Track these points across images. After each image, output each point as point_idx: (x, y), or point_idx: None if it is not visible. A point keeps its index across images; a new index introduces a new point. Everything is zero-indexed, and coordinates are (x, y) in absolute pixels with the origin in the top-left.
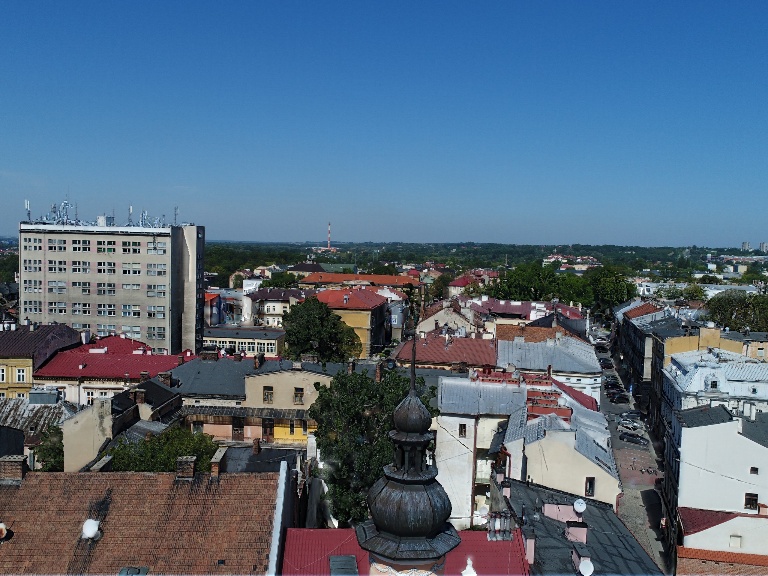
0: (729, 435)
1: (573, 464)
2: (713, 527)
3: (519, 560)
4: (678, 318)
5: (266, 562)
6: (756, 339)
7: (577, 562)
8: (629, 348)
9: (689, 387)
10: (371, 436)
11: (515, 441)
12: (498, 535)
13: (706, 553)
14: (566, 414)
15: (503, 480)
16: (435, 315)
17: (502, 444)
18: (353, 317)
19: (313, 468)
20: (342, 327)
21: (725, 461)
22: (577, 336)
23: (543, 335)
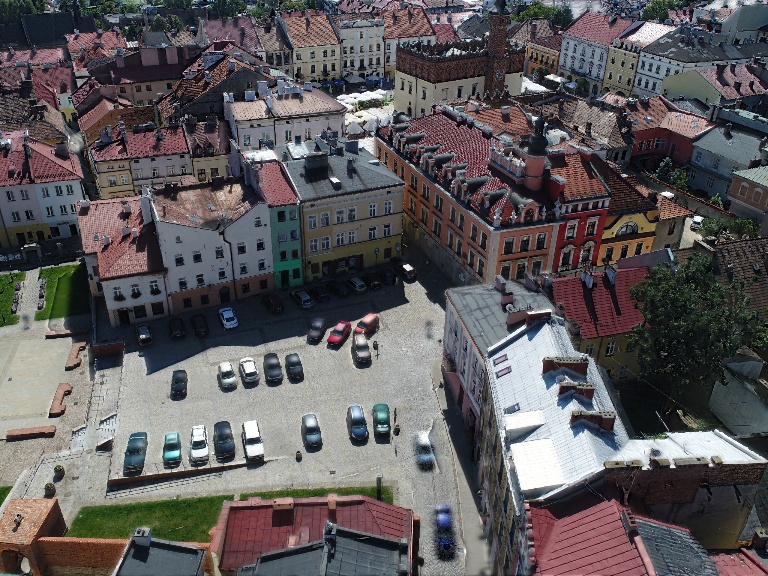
0: None
1: None
2: None
3: None
4: None
5: None
6: None
7: None
8: None
9: None
10: None
11: None
12: None
13: None
14: None
15: None
16: None
17: None
18: None
19: None
20: None
21: None
22: None
23: None
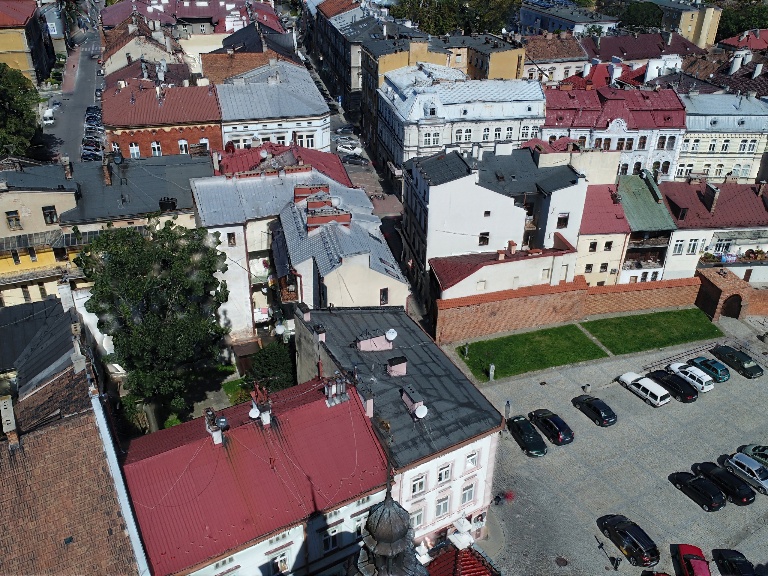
0: (468, 187)
1: (369, 281)
2: (465, 279)
3: (360, 418)
4: (379, 20)
5: (120, 521)
6: (455, 46)
7: (410, 405)
8: (328, 48)
9: (411, 116)
10: (164, 309)
11: (304, 262)
12: (336, 399)
13: (460, 301)
14: (346, 219)
15: (310, 318)
16: (124, 47)
17: (291, 267)
18: (2, 38)
19: (80, 326)
20: (5, 72)
21: (465, 210)
22: (290, 59)
23: (254, 62)
